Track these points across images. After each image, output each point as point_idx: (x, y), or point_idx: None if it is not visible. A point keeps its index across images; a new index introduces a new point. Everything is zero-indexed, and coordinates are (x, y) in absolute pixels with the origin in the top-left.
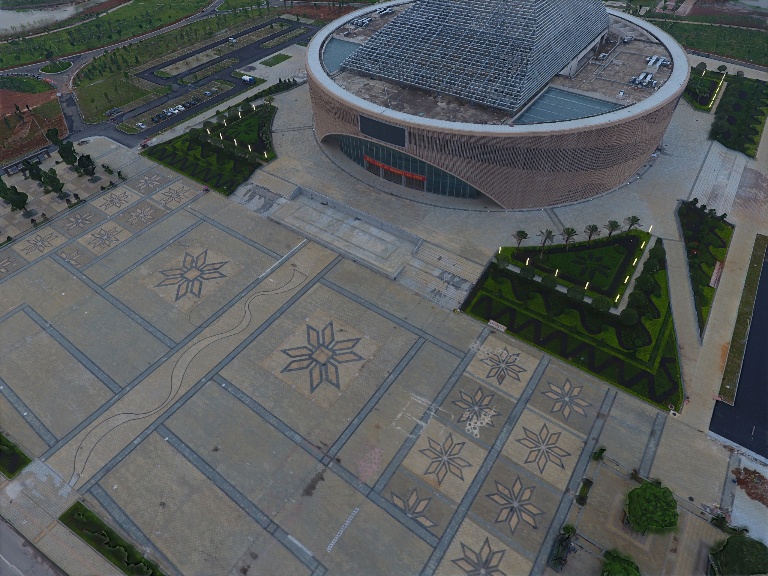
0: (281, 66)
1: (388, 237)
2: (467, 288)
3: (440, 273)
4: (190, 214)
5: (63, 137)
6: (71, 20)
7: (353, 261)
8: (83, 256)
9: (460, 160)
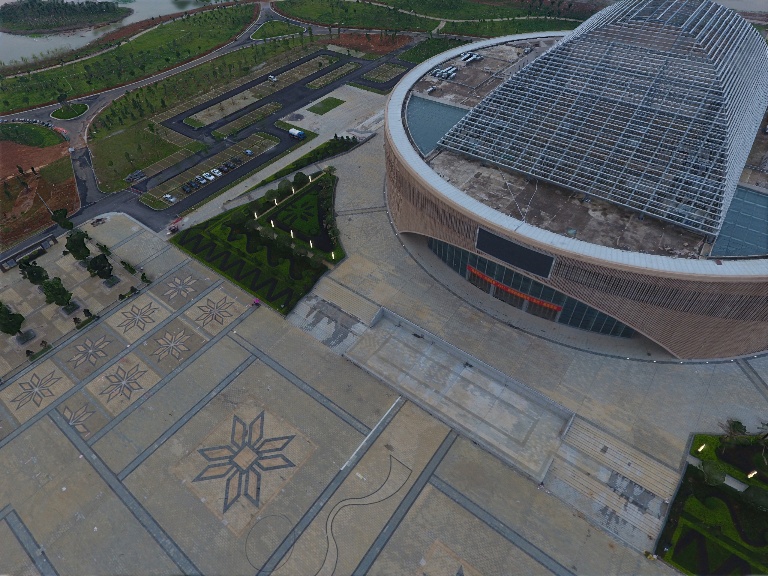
0: (333, 114)
1: (518, 401)
2: (658, 511)
3: (609, 477)
4: (237, 345)
5: (74, 212)
6: (89, 49)
7: (473, 443)
8: (93, 416)
9: (632, 303)
